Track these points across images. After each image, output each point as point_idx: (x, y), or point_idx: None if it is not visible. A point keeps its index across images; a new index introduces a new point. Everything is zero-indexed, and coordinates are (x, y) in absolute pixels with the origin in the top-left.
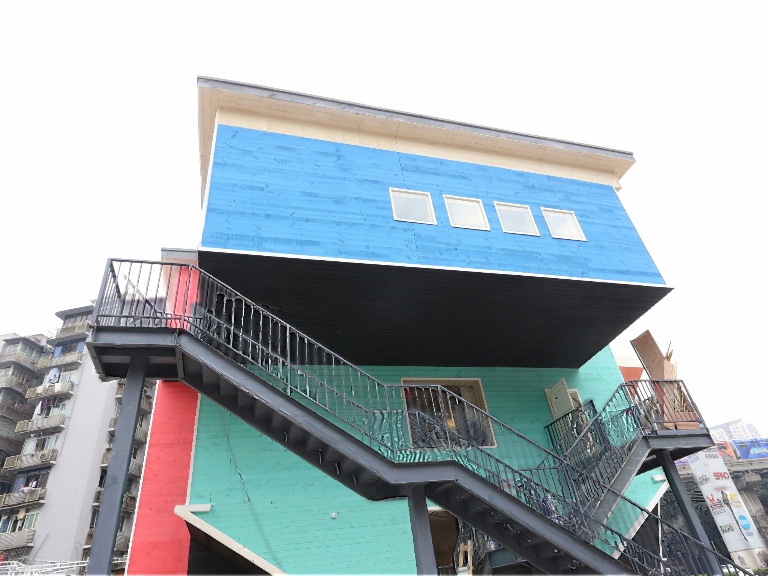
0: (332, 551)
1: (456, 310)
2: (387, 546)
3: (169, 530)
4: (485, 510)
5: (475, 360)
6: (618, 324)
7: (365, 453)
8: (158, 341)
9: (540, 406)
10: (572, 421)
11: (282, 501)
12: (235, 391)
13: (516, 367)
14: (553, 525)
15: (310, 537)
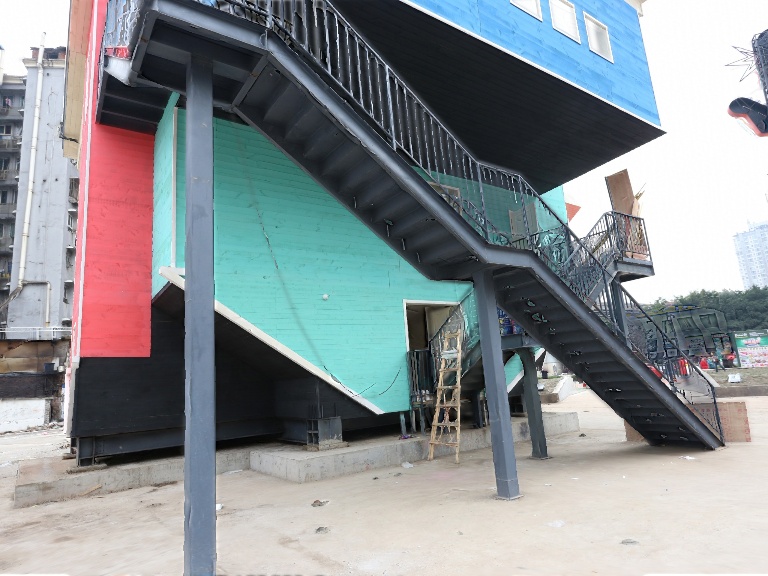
0: (323, 329)
1: (482, 107)
2: (372, 329)
3: (125, 295)
4: (524, 301)
5: (461, 169)
6: (599, 159)
7: (462, 229)
8: (242, 39)
9: (503, 225)
10: (538, 241)
11: (275, 277)
12: (307, 136)
13: (489, 185)
14: (592, 317)
15: (303, 314)
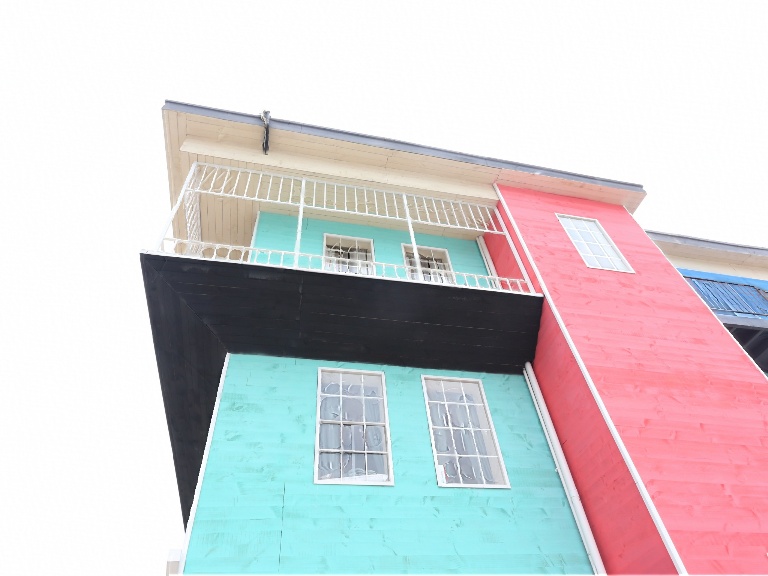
0: None
1: None
2: None
3: None
4: None
5: None
6: None
7: None
8: None
9: None
10: None
11: None
12: None
13: None
14: None
15: None
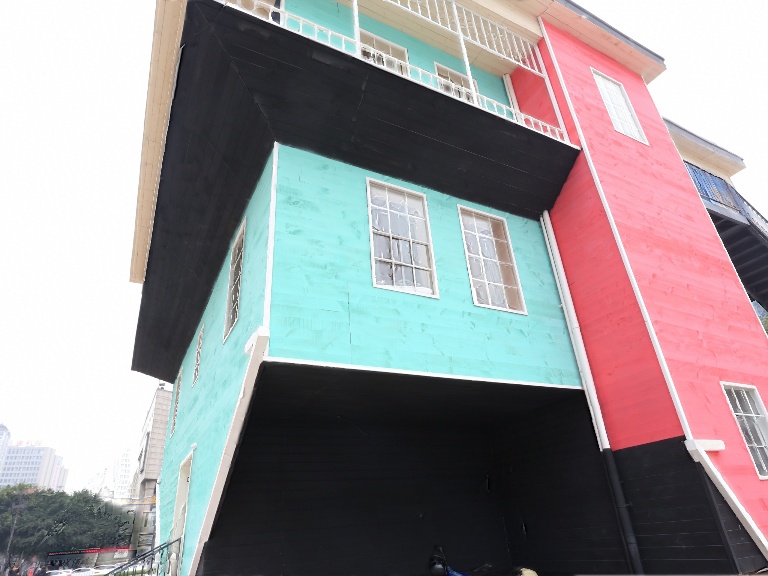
0: None
1: None
2: None
3: None
4: None
5: None
6: None
7: None
8: None
9: None
10: None
11: None
12: None
13: None
14: None
15: None
